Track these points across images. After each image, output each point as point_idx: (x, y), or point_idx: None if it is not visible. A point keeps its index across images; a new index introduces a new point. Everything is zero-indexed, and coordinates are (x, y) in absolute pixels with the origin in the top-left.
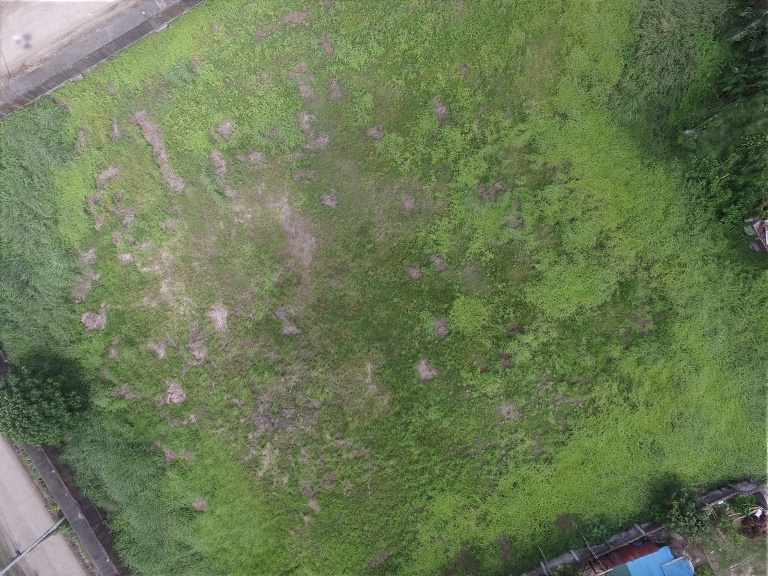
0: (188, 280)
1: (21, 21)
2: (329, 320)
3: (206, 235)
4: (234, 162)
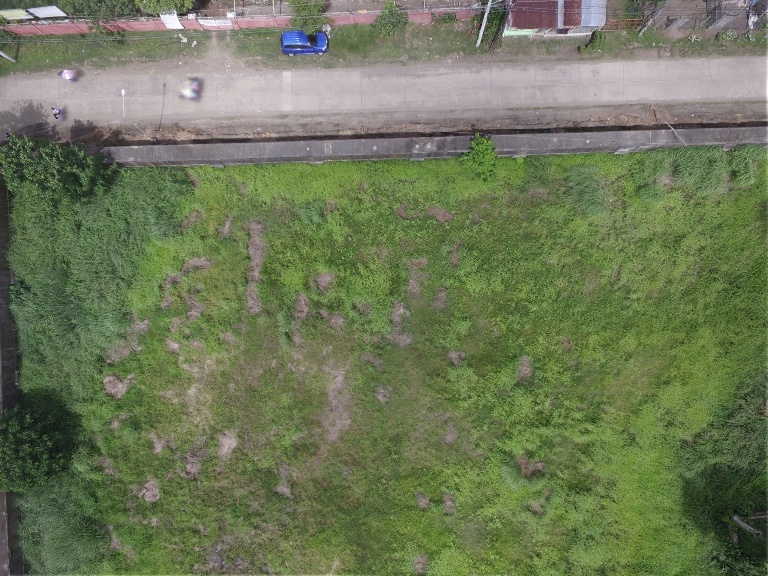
0: (217, 396)
1: (196, 84)
2: (323, 502)
3: (255, 364)
4: (316, 315)
